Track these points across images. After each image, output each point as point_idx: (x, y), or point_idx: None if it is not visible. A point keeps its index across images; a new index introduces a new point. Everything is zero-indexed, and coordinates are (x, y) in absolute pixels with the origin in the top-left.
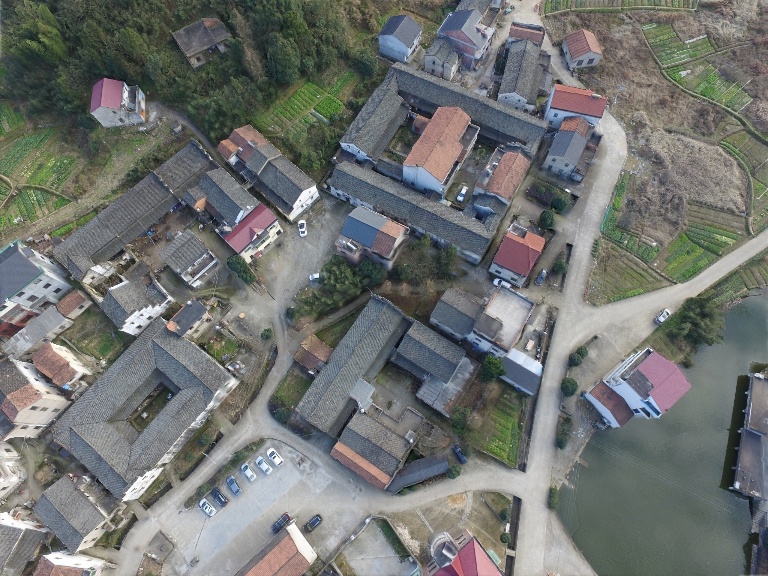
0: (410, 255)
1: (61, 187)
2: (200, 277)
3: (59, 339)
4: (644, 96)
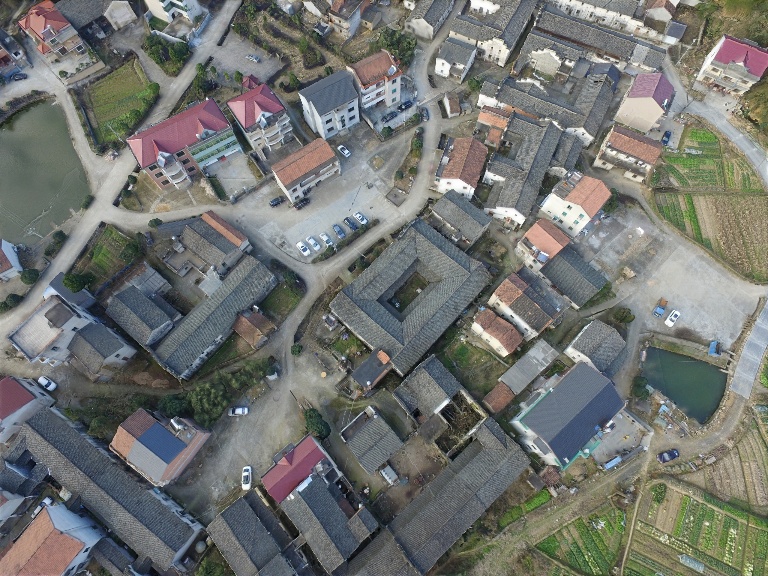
0: None
1: (553, 572)
2: None
3: (510, 364)
4: None
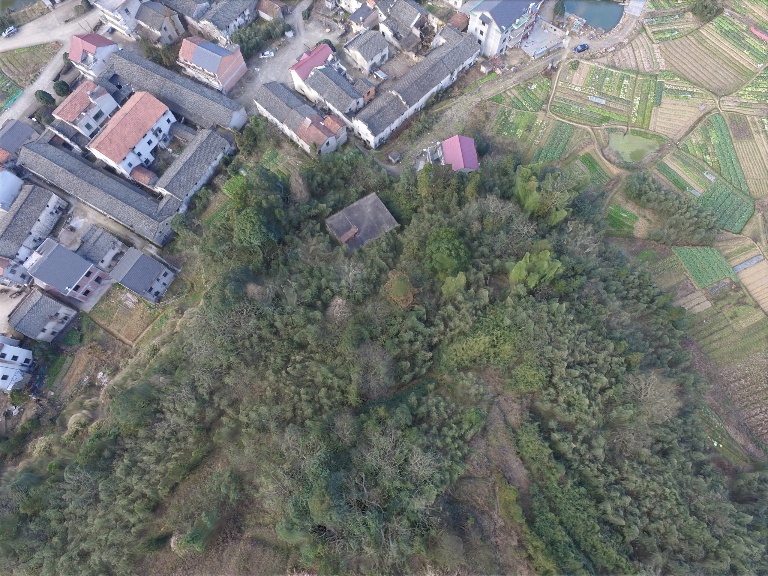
0: None
1: (500, 109)
2: None
3: None
4: None
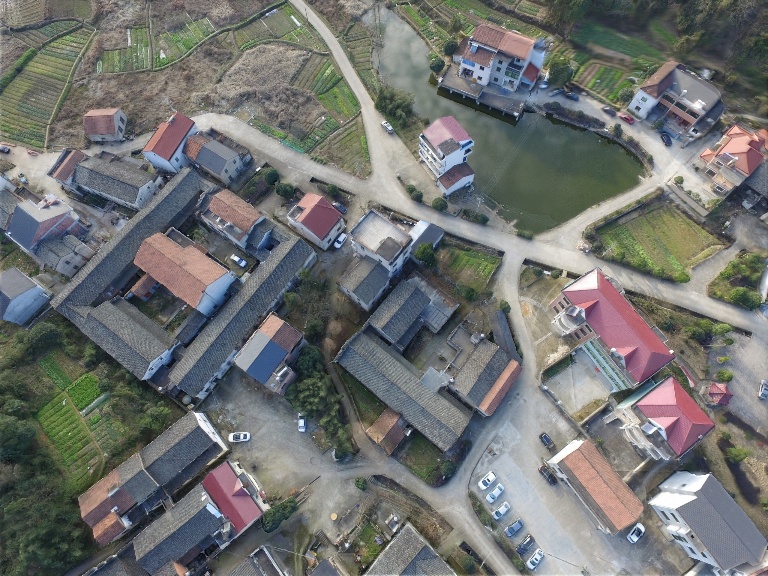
0: (295, 321)
1: None
2: (280, 571)
3: None
4: (176, 90)
